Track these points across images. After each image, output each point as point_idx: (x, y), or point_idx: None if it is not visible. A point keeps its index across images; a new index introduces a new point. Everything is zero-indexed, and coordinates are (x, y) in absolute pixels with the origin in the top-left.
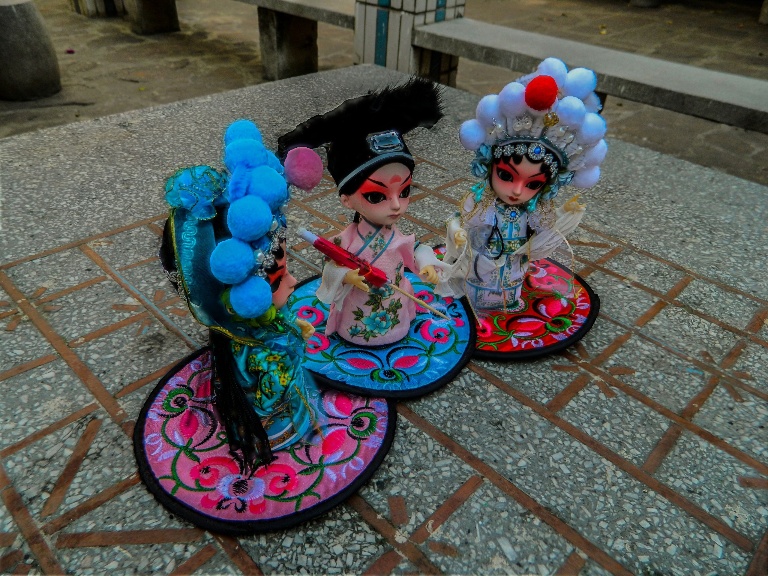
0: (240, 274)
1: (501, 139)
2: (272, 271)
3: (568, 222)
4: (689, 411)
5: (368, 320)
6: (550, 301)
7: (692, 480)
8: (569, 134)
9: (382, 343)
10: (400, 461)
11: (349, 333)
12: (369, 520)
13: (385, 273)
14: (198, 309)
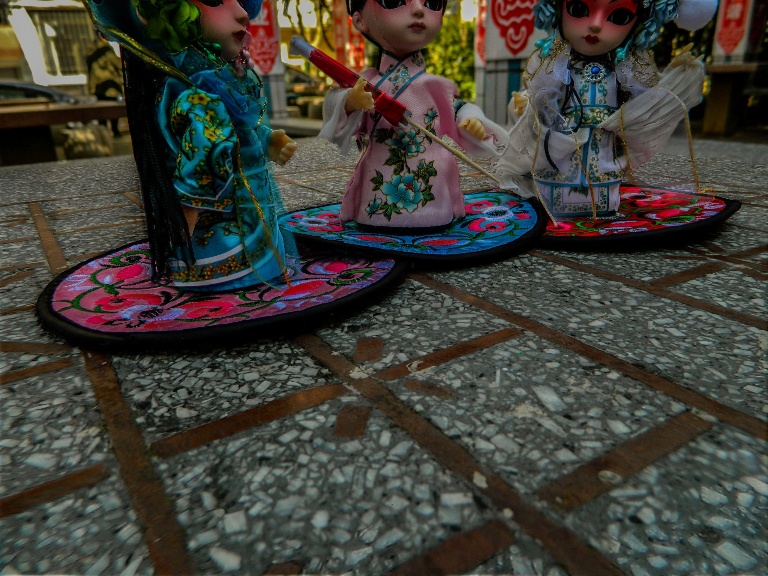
0: None
1: None
2: None
3: (678, 83)
4: None
5: (389, 187)
6: None
7: None
8: None
9: (409, 225)
10: (394, 311)
11: (367, 212)
12: (318, 355)
13: (410, 117)
14: (97, 5)
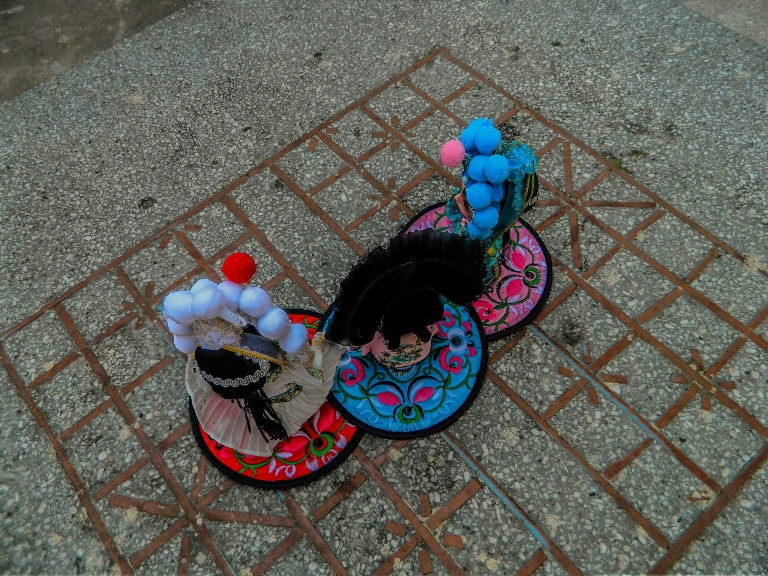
0: None
1: None
2: None
3: None
4: (194, 273)
5: None
6: None
7: (227, 229)
8: None
9: None
10: None
11: None
12: (410, 210)
13: None
14: None
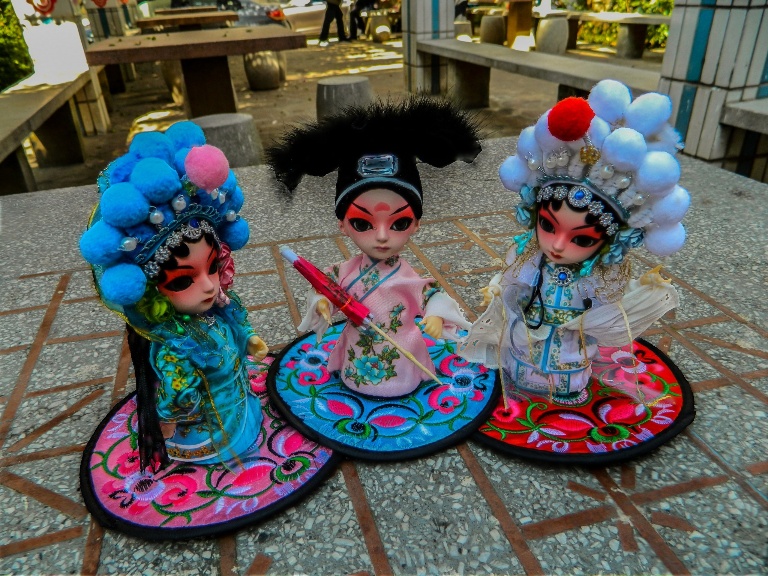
0: (96, 255)
1: (540, 179)
2: (169, 267)
3: (644, 300)
4: None
5: (359, 363)
6: (622, 403)
7: None
8: (621, 177)
9: (374, 393)
10: (301, 521)
11: (344, 374)
12: (223, 568)
13: (376, 313)
14: None
